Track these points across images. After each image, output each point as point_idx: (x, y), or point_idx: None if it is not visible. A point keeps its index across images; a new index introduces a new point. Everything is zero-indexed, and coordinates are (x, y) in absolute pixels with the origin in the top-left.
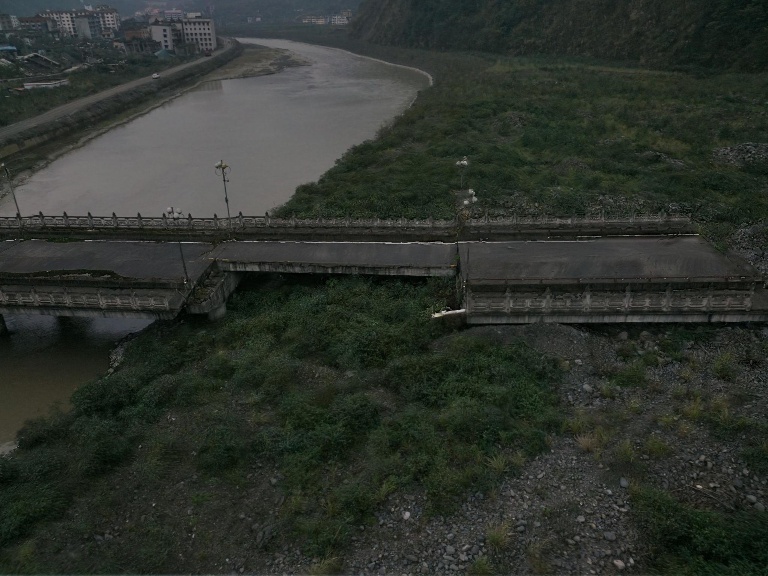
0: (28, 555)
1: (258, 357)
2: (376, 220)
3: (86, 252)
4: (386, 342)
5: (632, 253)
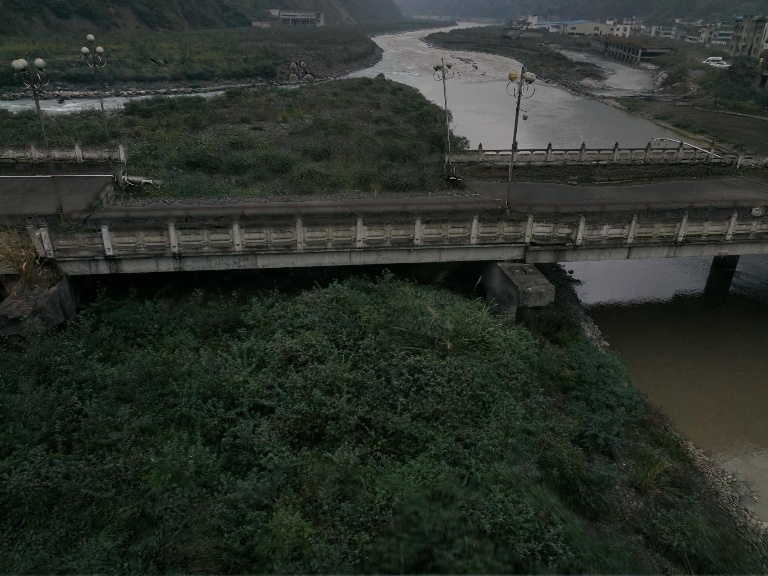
0: (371, 137)
1: (331, 176)
2: (236, 234)
3: (681, 201)
4: None
5: None
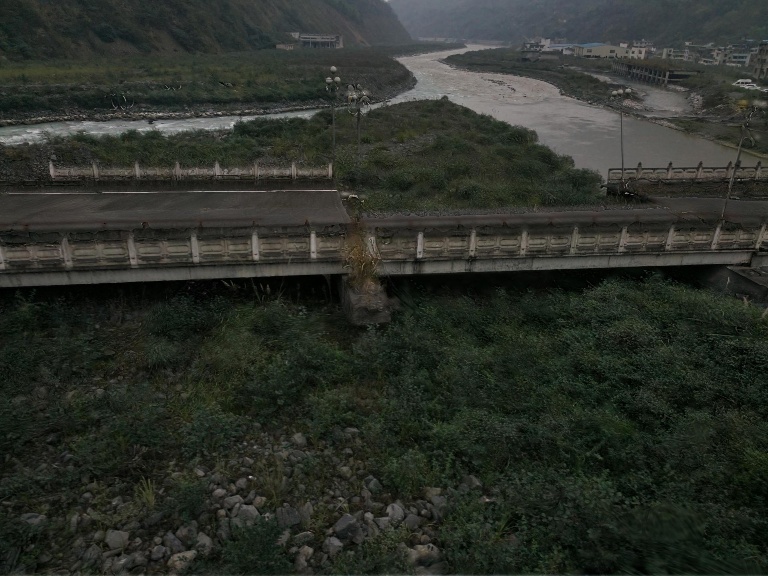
0: (491, 156)
1: (492, 192)
2: None
3: None
4: None
5: (106, 212)
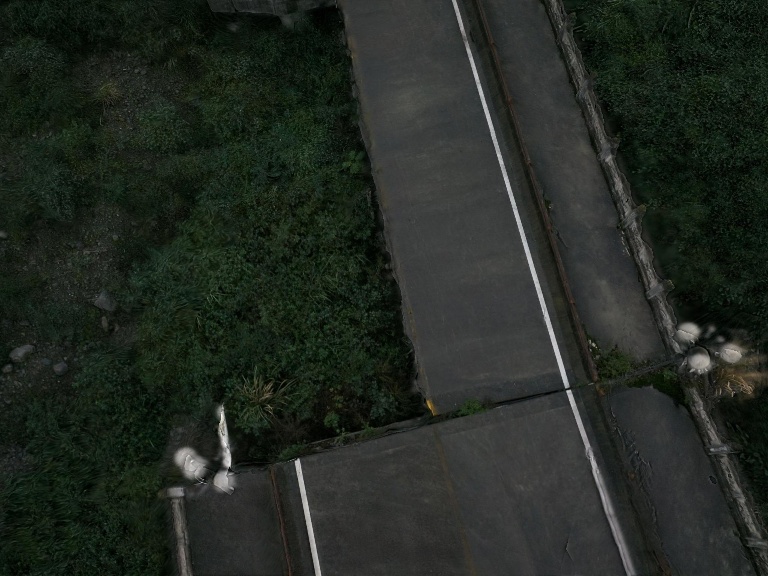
0: None
1: (66, 153)
2: (607, 152)
3: None
4: (161, 337)
5: None
